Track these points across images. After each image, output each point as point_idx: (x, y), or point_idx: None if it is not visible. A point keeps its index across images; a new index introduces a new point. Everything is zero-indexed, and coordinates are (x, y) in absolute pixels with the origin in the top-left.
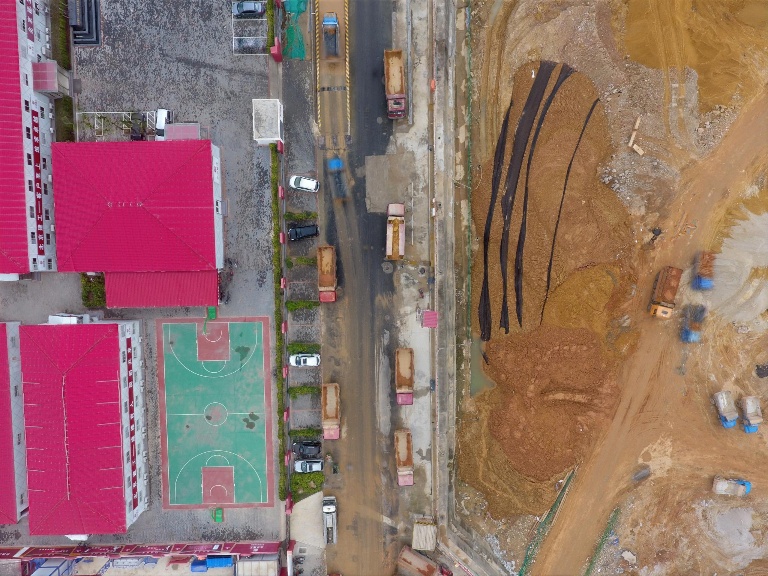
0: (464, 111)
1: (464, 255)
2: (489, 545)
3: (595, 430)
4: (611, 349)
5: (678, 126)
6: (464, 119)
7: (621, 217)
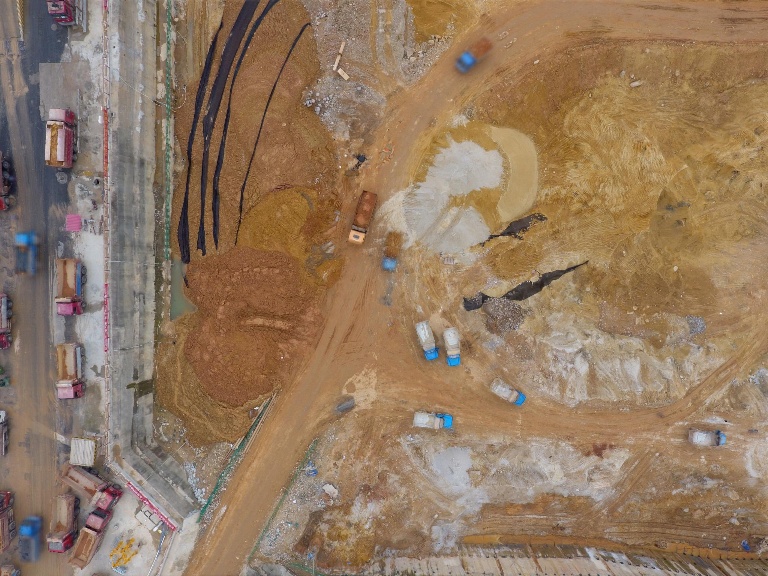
0: (166, 29)
1: (165, 175)
2: (186, 473)
3: (297, 358)
4: (311, 275)
5: (385, 52)
6: (166, 37)
7: (322, 141)
